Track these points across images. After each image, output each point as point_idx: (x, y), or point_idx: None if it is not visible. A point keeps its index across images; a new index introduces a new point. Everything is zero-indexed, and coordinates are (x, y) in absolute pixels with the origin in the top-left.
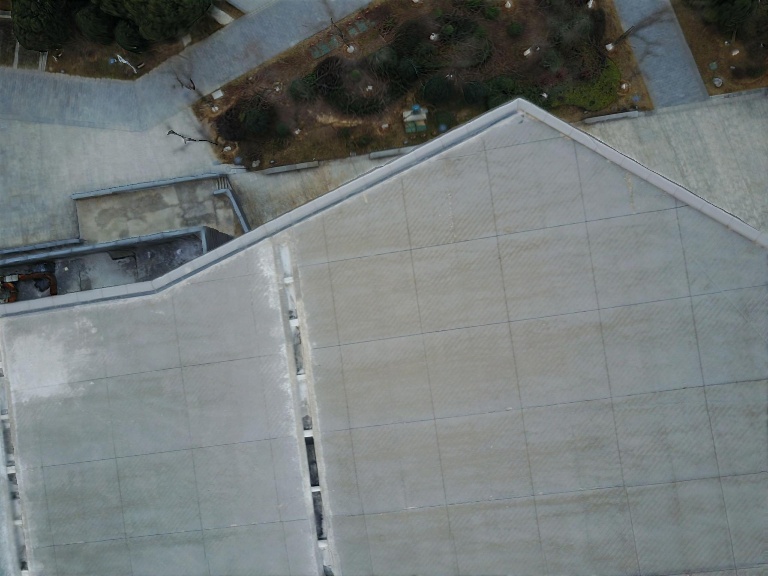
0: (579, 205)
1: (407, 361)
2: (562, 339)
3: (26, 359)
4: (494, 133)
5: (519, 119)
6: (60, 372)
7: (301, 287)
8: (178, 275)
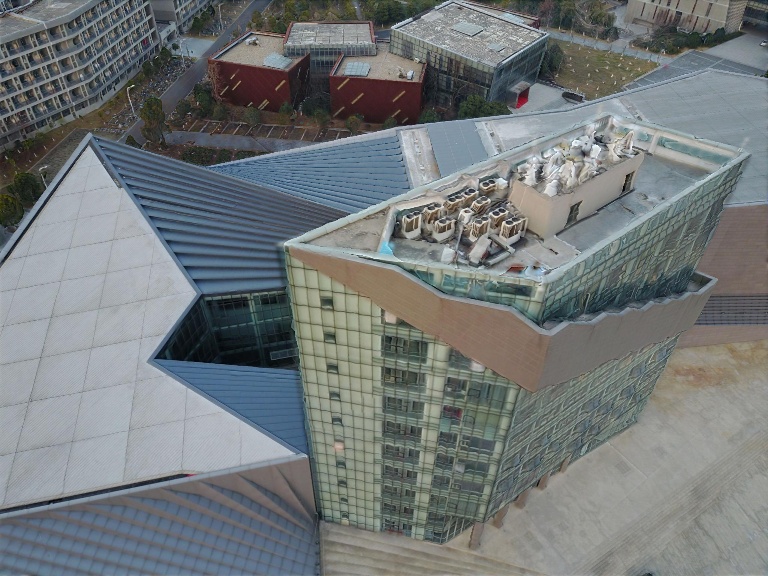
0: (747, 86)
1: (695, 120)
2: (762, 112)
3: (506, 129)
4: (701, 75)
5: (710, 72)
6: (524, 131)
7: (636, 107)
8: (577, 106)
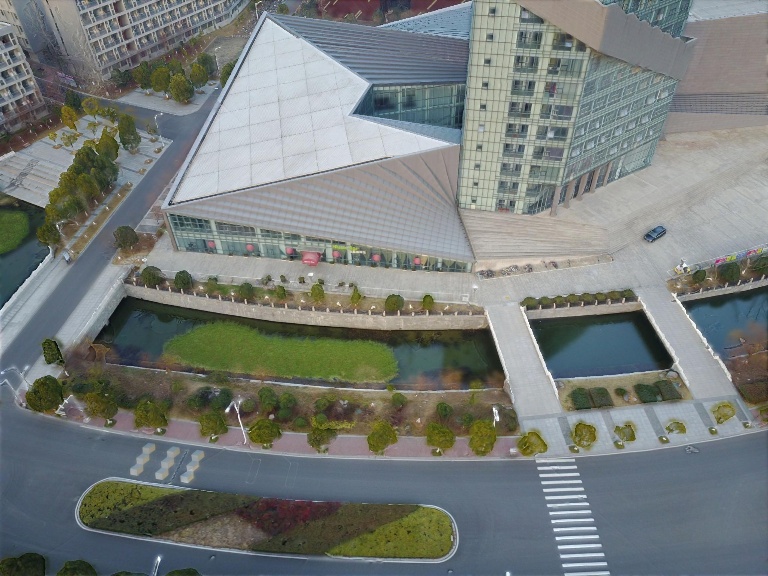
0: None
1: None
2: None
3: None
4: None
5: None
6: None
7: None
8: None
